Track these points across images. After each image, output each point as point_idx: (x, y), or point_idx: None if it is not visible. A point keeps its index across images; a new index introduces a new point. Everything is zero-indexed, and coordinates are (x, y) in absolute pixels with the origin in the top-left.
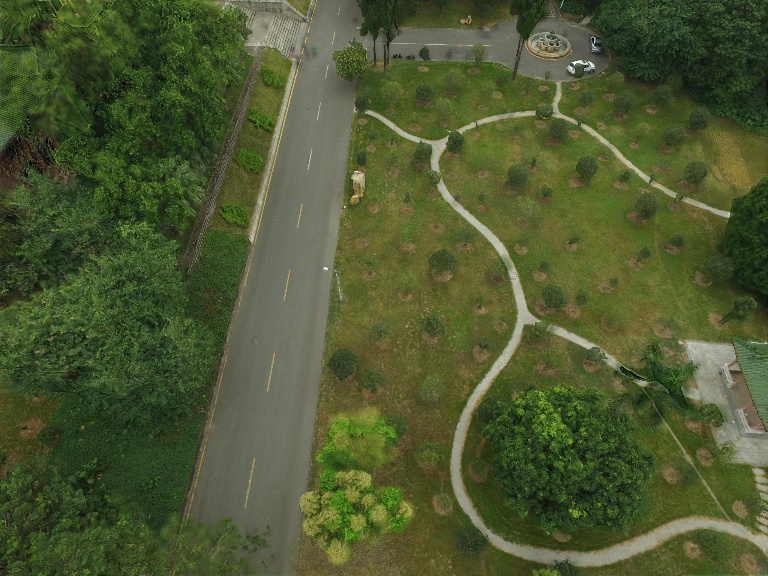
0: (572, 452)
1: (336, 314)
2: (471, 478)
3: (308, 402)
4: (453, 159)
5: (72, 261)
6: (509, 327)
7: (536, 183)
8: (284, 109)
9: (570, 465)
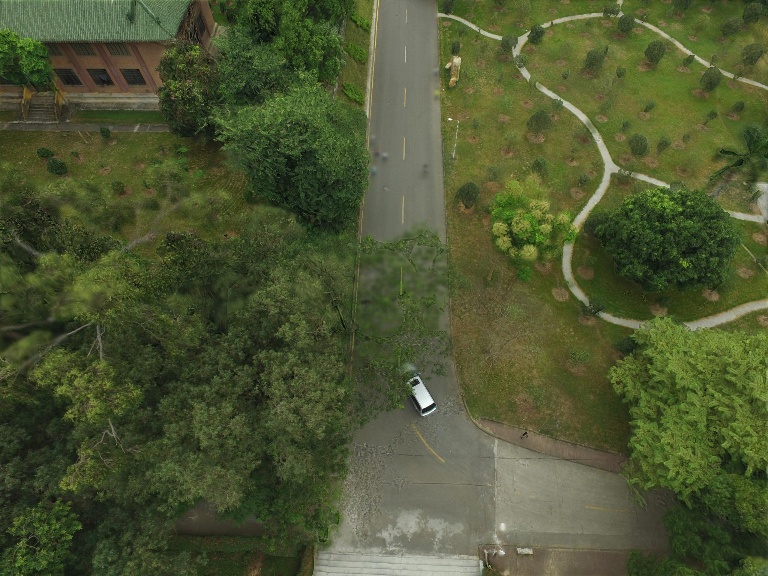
0: (682, 217)
1: (451, 168)
2: (581, 277)
3: (438, 230)
4: (532, 52)
5: (252, 105)
6: (599, 174)
7: (609, 69)
8: (375, 15)
9: (682, 224)
